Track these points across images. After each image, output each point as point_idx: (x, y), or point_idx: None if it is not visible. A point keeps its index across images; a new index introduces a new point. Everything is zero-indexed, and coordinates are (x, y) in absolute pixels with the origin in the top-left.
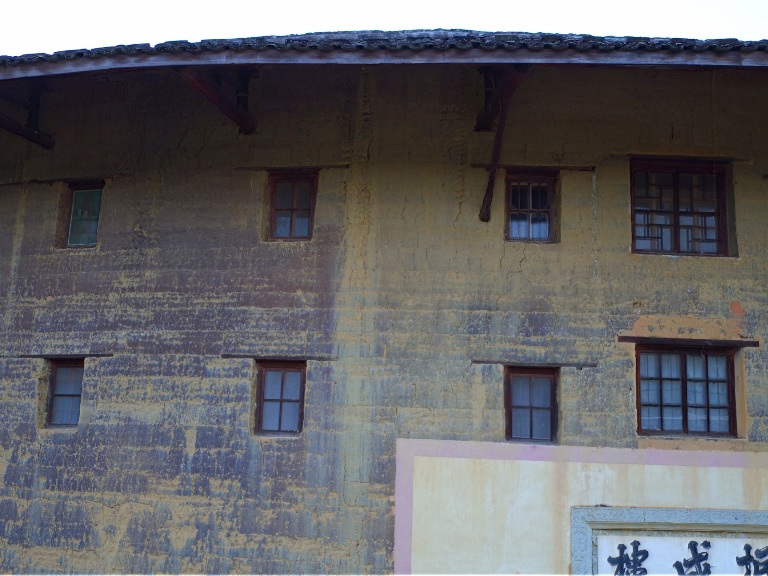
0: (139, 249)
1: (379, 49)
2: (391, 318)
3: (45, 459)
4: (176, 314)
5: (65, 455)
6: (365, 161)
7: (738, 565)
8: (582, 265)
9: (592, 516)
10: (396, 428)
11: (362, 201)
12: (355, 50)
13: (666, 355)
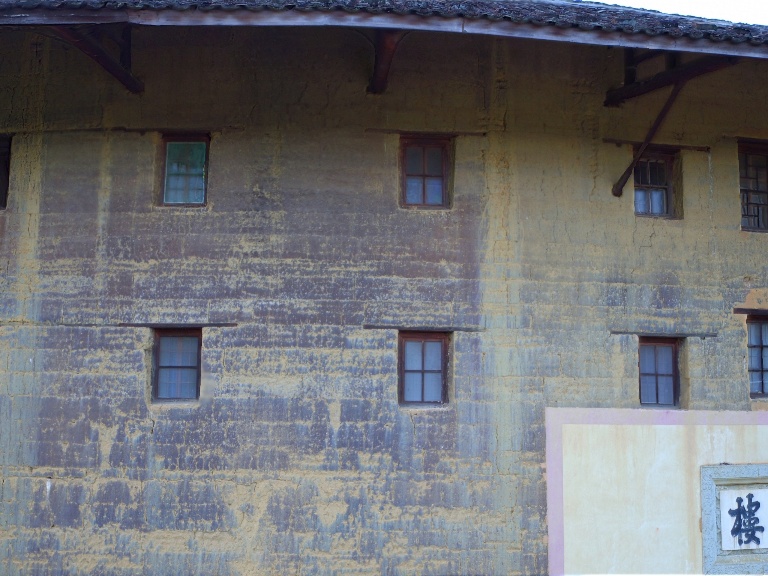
0: (261, 211)
1: (615, 31)
2: (535, 290)
3: (161, 437)
4: (309, 282)
5: (186, 432)
6: (502, 130)
7: None
8: (703, 241)
9: (718, 474)
10: (544, 397)
11: (501, 171)
12: (591, 30)
13: (764, 324)
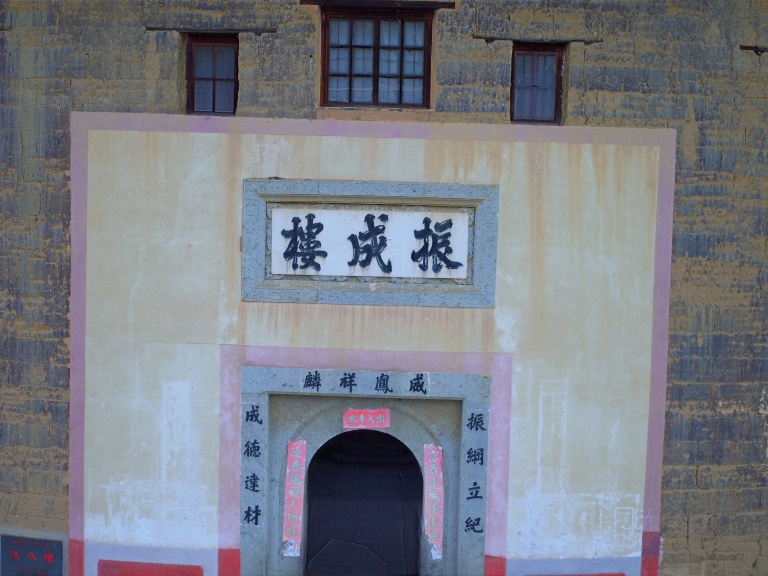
0: None
1: None
2: None
3: None
4: None
5: None
6: None
7: (416, 238)
8: None
9: (264, 189)
10: (70, 101)
11: None
12: None
13: (360, 21)
